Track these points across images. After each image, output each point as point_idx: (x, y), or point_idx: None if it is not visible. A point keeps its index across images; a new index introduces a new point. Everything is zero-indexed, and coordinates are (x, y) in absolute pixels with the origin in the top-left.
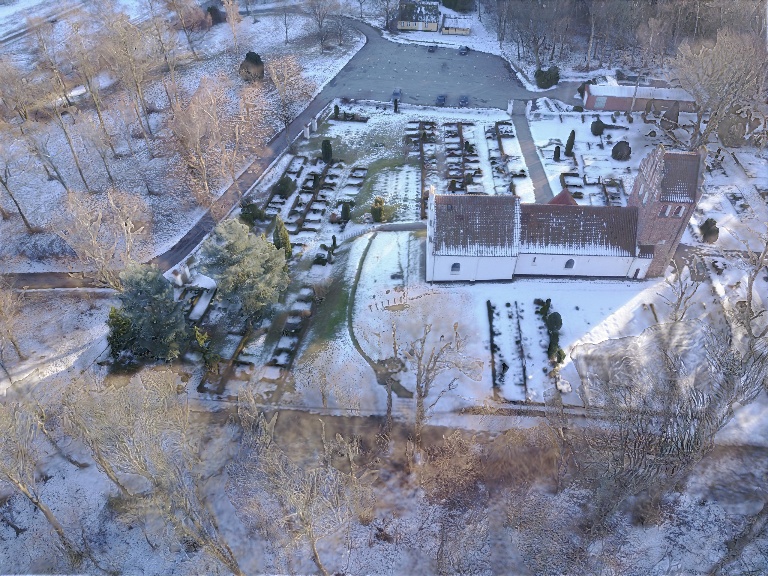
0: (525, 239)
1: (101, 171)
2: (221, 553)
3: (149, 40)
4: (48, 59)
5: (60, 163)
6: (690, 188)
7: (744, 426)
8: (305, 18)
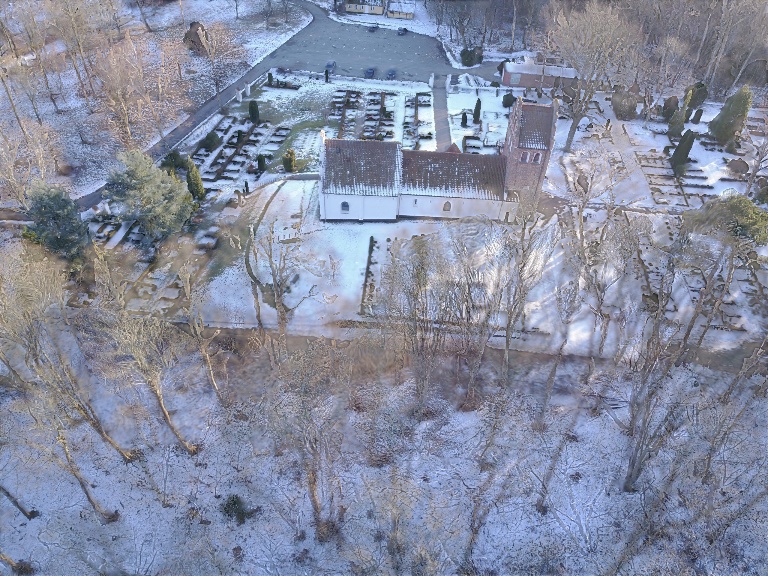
0: (406, 182)
1: (29, 113)
2: (82, 410)
3: (93, 3)
4: (0, 20)
5: (5, 116)
6: (545, 137)
7: (573, 340)
8: None
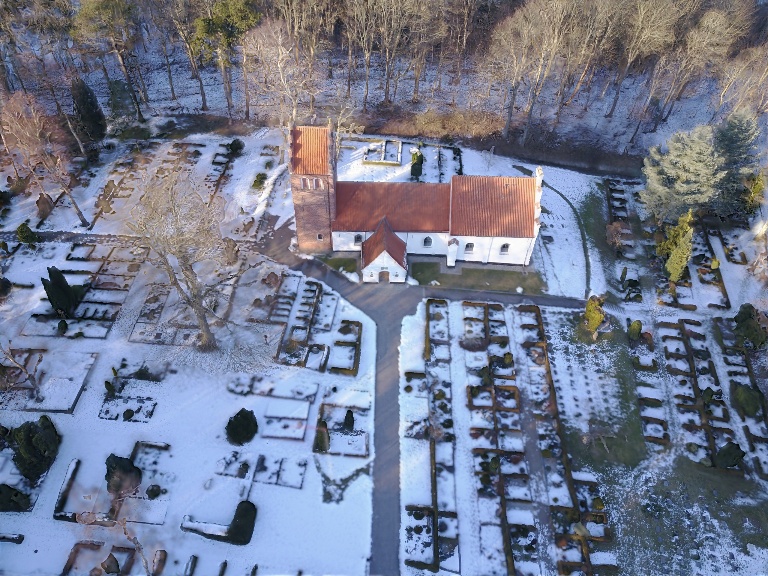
0: None
1: None
2: None
3: None
4: None
5: None
6: None
7: None
8: None
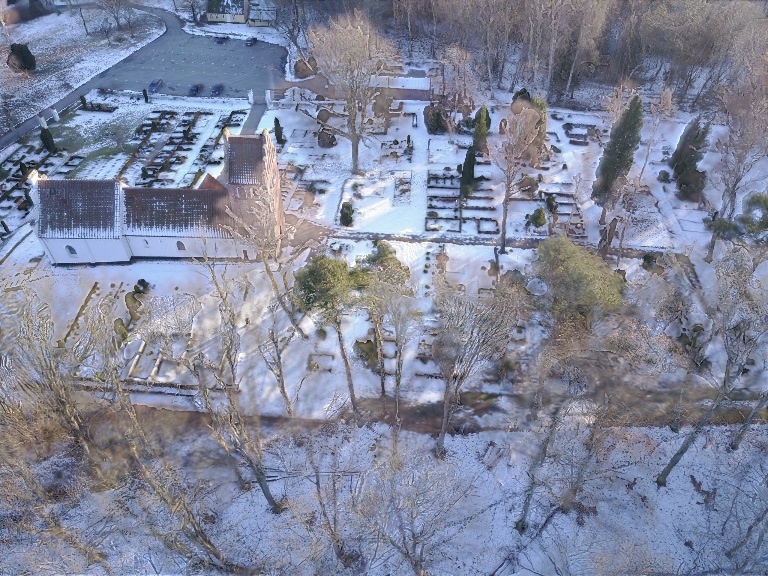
0: (131, 222)
1: None
2: None
3: None
4: None
5: None
6: (257, 171)
7: (265, 397)
8: (100, 10)
